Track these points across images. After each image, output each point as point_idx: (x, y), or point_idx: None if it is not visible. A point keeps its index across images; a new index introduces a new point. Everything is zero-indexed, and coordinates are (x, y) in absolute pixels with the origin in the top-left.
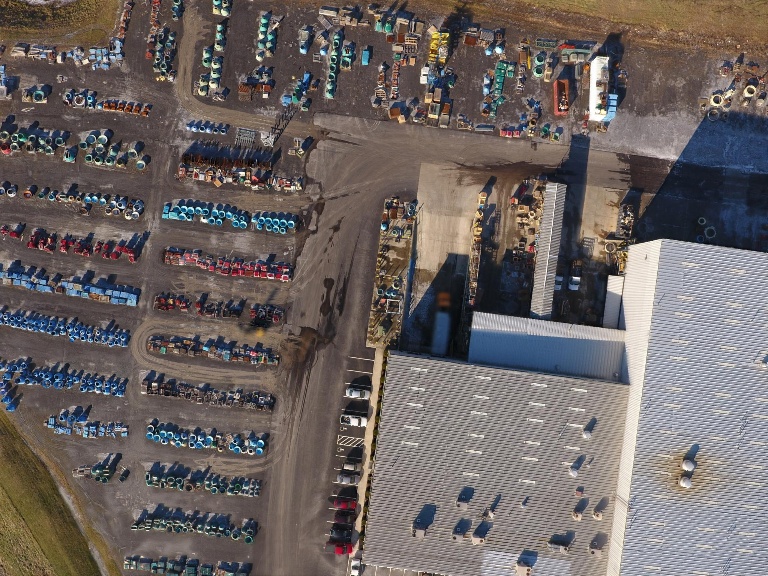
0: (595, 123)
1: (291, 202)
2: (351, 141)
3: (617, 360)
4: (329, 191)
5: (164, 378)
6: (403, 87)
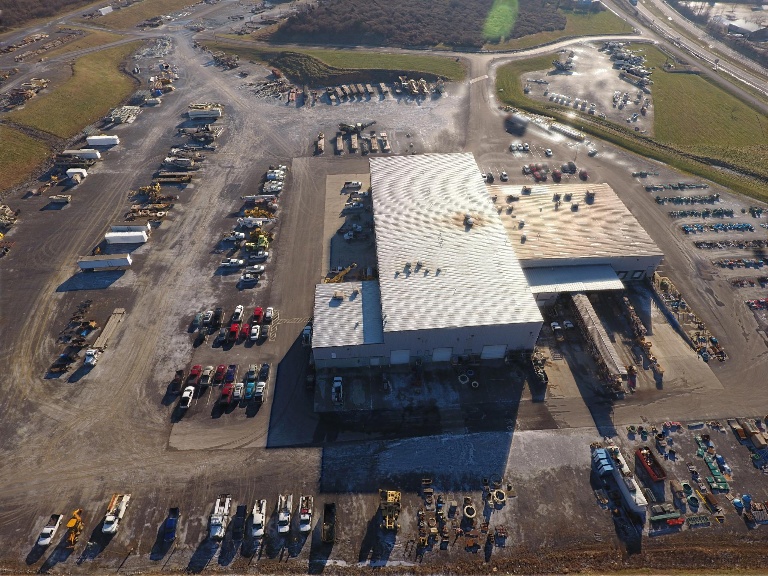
0: None
1: None
2: None
3: None
4: None
5: None
6: None
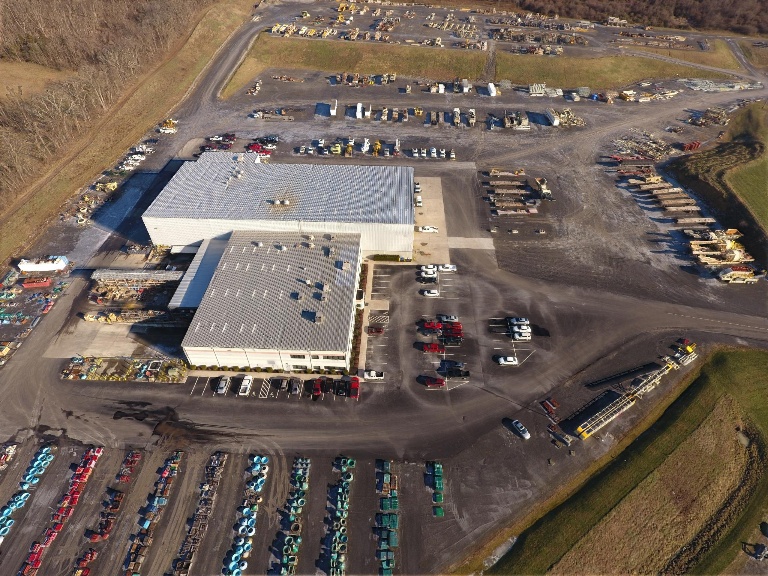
0: (66, 268)
1: (25, 454)
2: None
3: (222, 241)
4: (31, 422)
5: (169, 574)
6: None
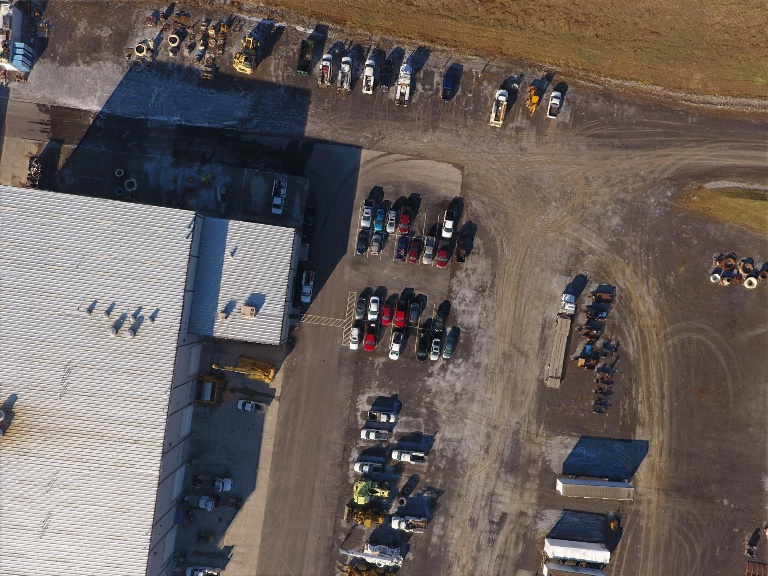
0: (15, 73)
1: None
2: None
3: None
4: None
5: None
6: None
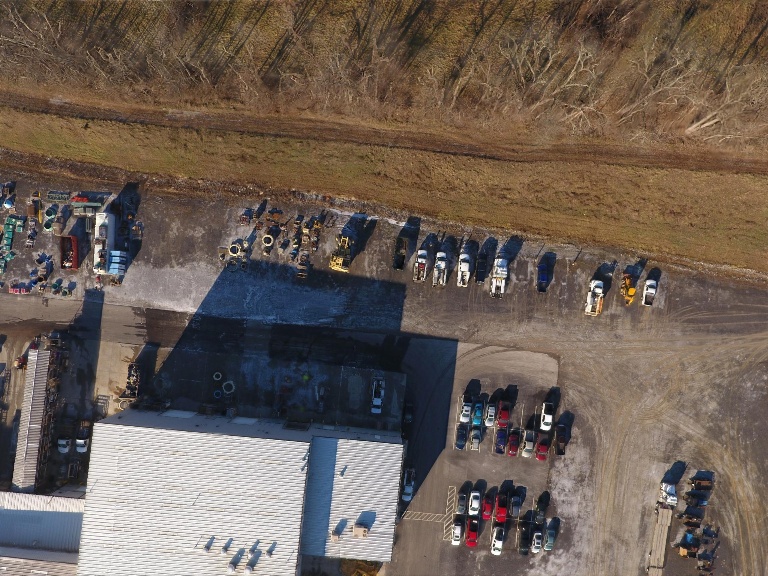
0: (109, 277)
1: None
2: None
3: None
4: None
5: None
6: None
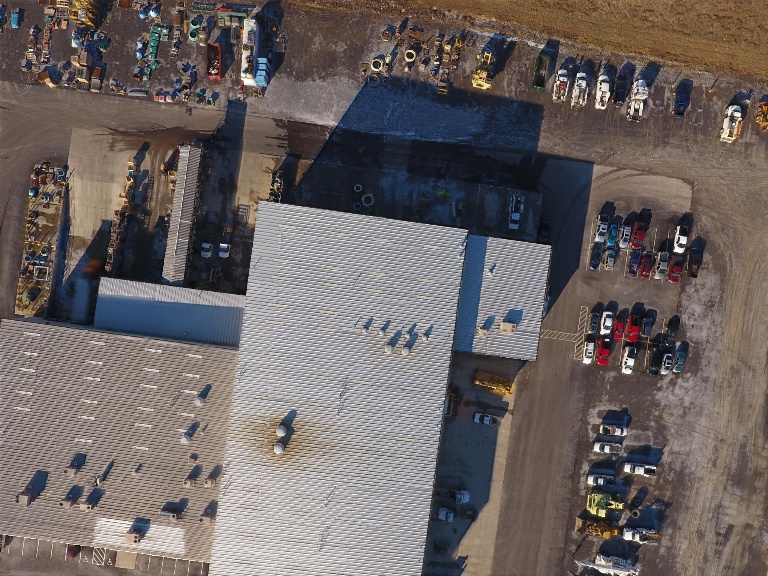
0: (252, 88)
1: None
2: (1, 105)
3: None
4: None
5: None
6: (55, 51)
